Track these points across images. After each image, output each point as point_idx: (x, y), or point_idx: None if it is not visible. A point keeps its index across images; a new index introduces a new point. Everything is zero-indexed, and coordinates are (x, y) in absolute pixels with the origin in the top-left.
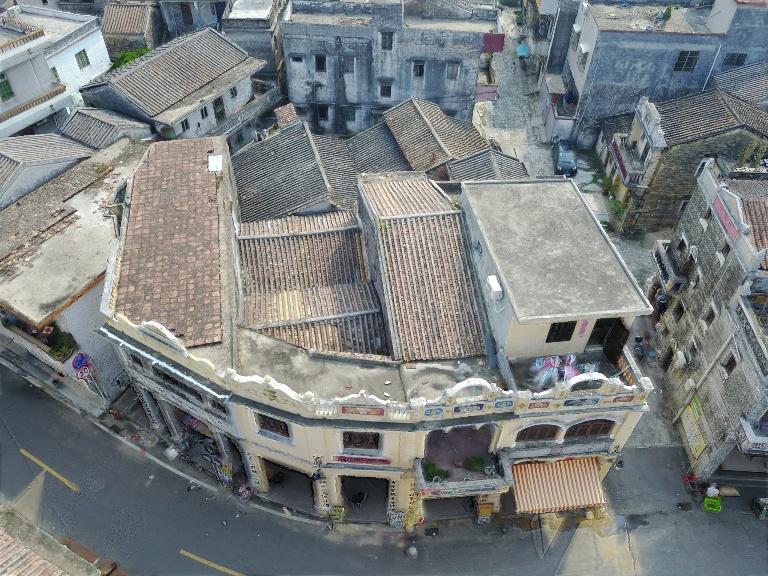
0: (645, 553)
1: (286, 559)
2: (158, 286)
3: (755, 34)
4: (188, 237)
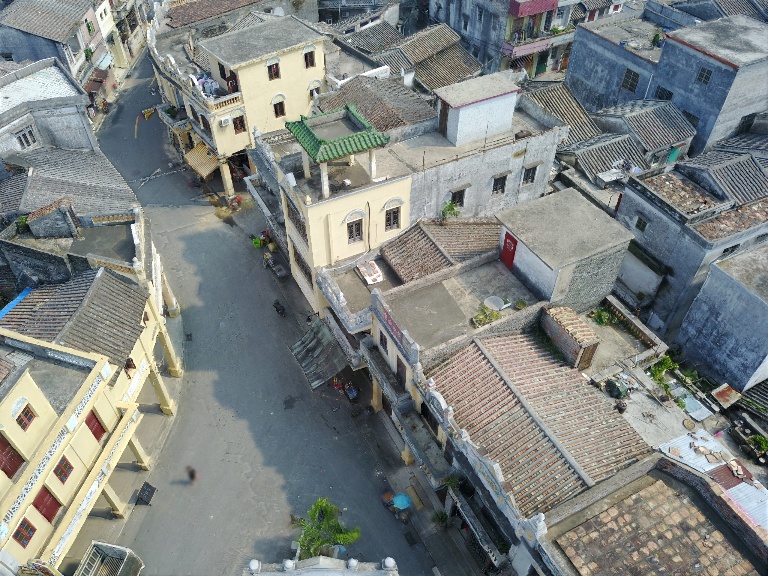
0: (214, 229)
1: (149, 139)
2: (194, 8)
3: (679, 74)
4: (229, 3)
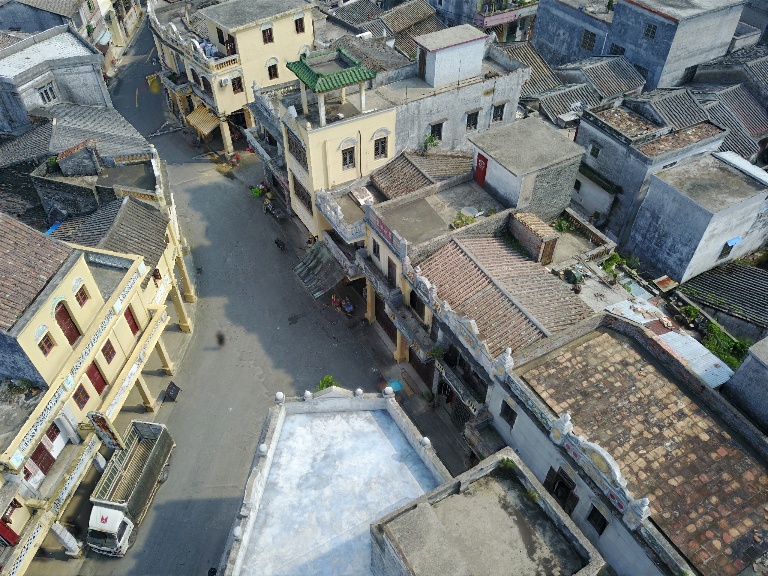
0: (216, 182)
1: (150, 108)
2: None
3: (630, 31)
4: None
